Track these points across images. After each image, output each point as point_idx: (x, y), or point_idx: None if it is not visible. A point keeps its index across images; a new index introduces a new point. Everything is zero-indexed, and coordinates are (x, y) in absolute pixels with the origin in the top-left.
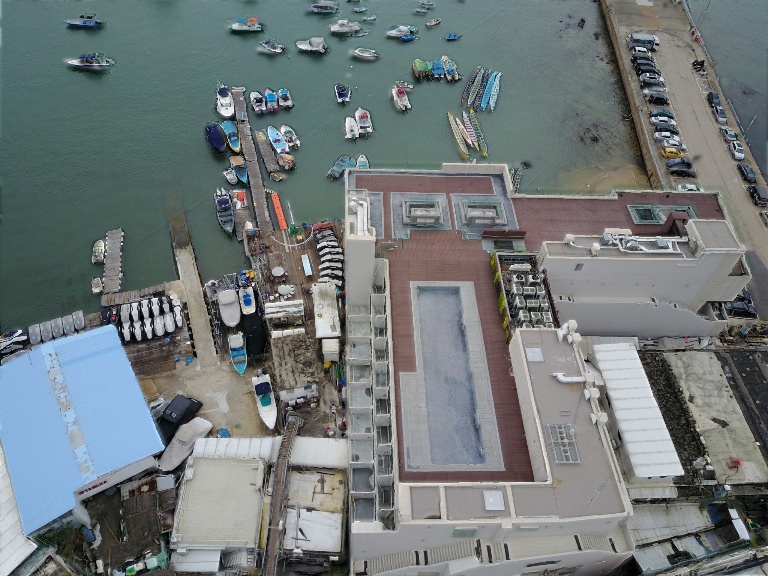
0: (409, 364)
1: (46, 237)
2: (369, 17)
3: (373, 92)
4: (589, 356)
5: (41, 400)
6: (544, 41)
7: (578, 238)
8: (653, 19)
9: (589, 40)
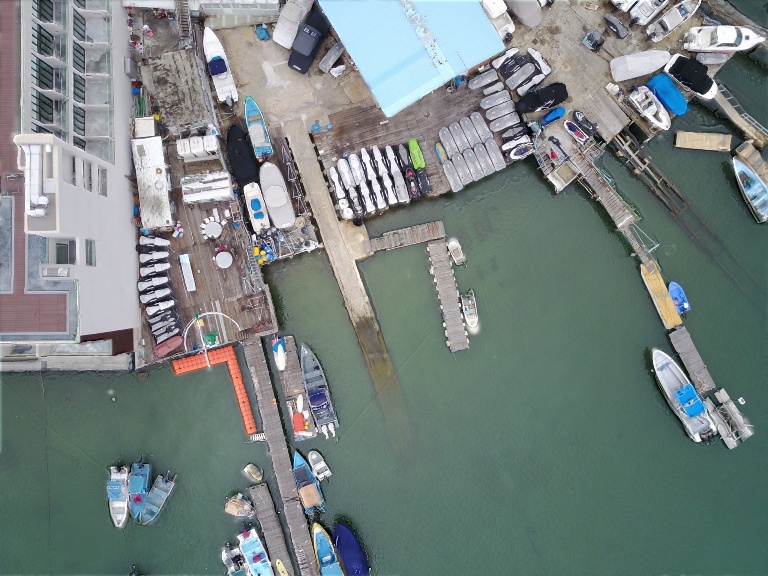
0: None
1: (550, 343)
2: None
3: None
4: None
5: (432, 8)
6: None
7: None
8: None
9: None
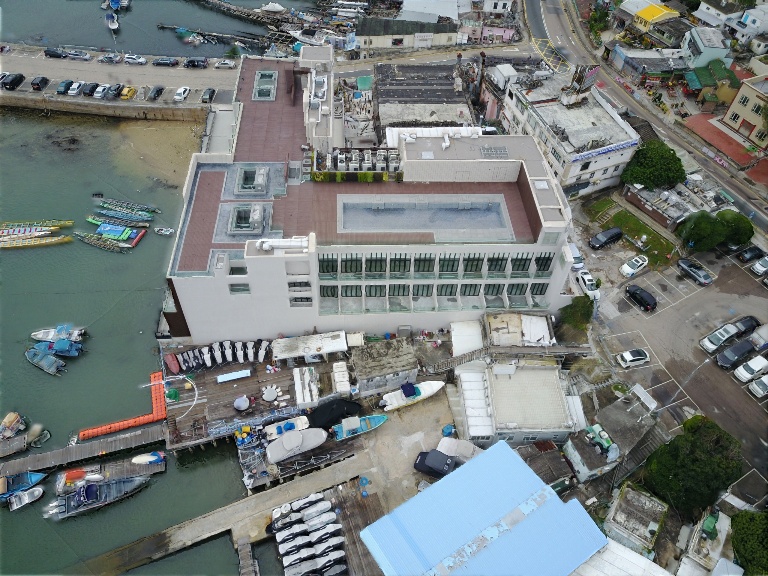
0: (427, 236)
1: None
2: None
3: None
4: None
5: (476, 575)
6: None
7: None
8: None
9: None
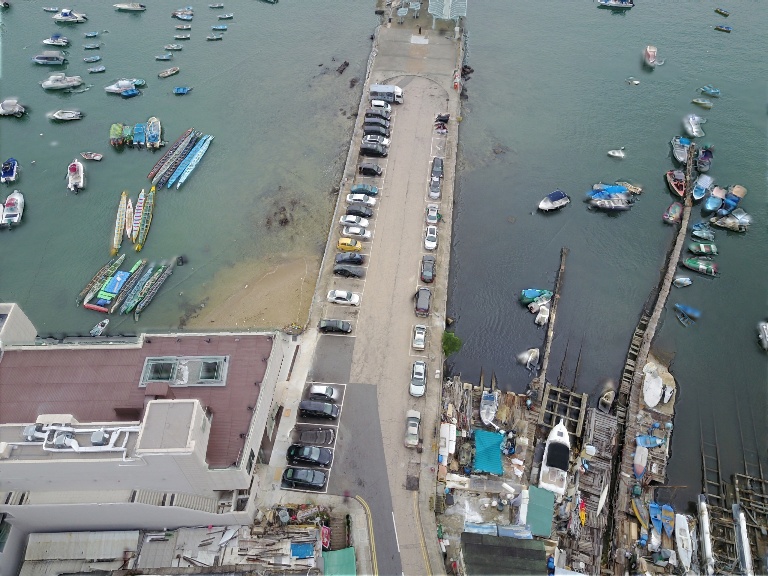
0: None
1: None
2: (97, 69)
3: (51, 167)
4: None
5: None
6: (288, 92)
7: (3, 428)
8: (419, 61)
9: (341, 88)
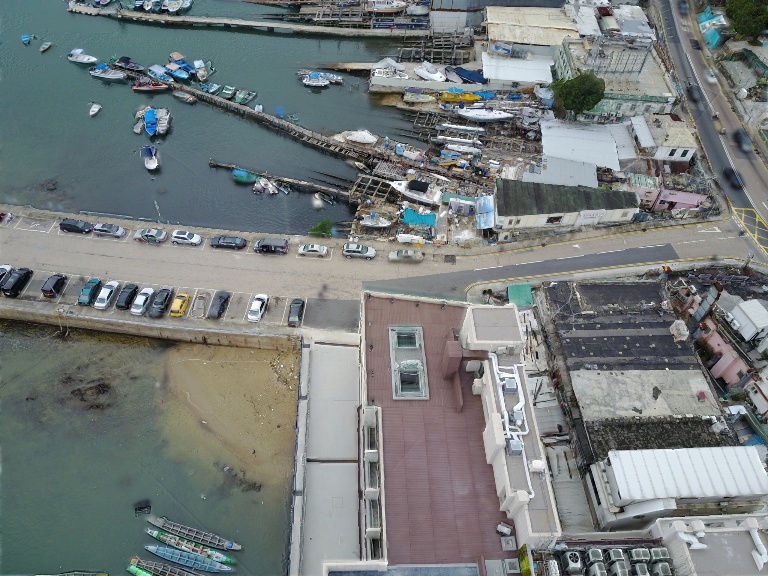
0: None
1: None
2: None
3: None
4: (618, 505)
5: None
6: None
7: (512, 484)
8: None
9: None
